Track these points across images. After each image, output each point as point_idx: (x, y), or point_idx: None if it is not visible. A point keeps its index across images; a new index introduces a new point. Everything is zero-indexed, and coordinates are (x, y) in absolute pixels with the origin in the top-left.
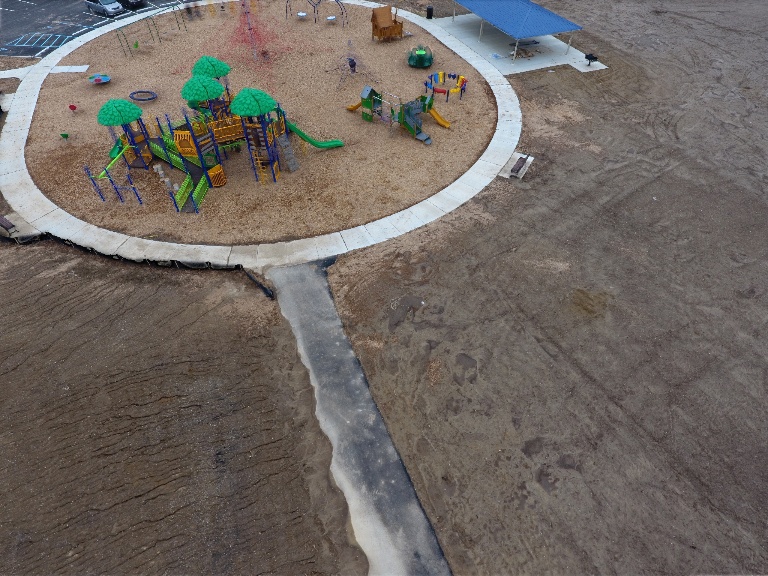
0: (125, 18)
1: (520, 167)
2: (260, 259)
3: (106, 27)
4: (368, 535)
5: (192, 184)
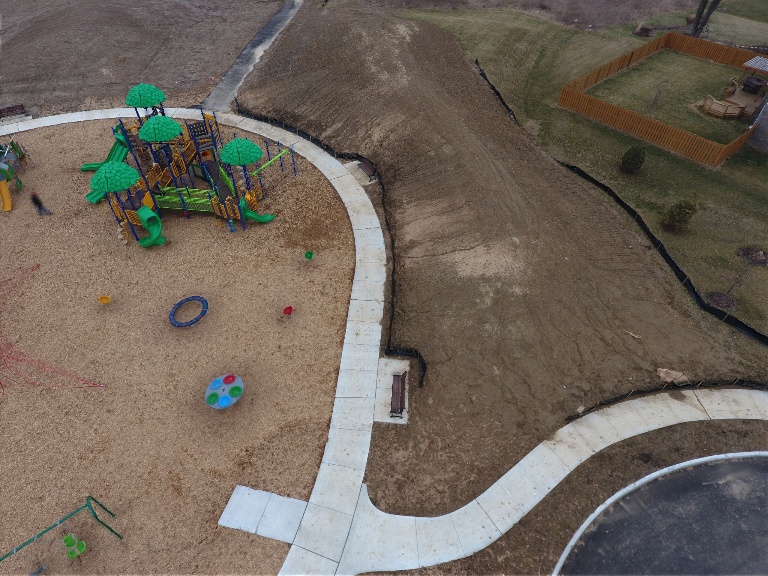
0: None
1: None
2: (226, 117)
3: None
4: None
5: None
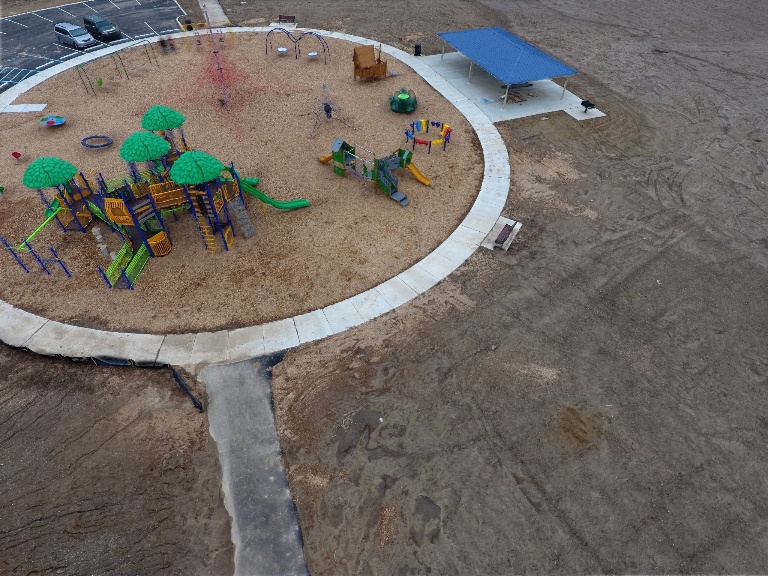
0: (96, 51)
1: (505, 239)
2: (195, 353)
3: (74, 60)
4: None
5: (131, 253)
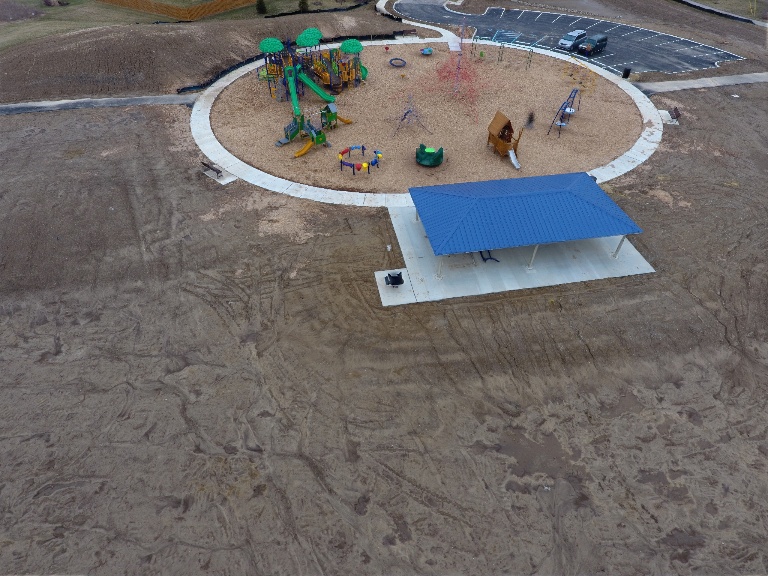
0: (556, 52)
1: None
2: (209, 92)
3: (533, 48)
4: None
5: None
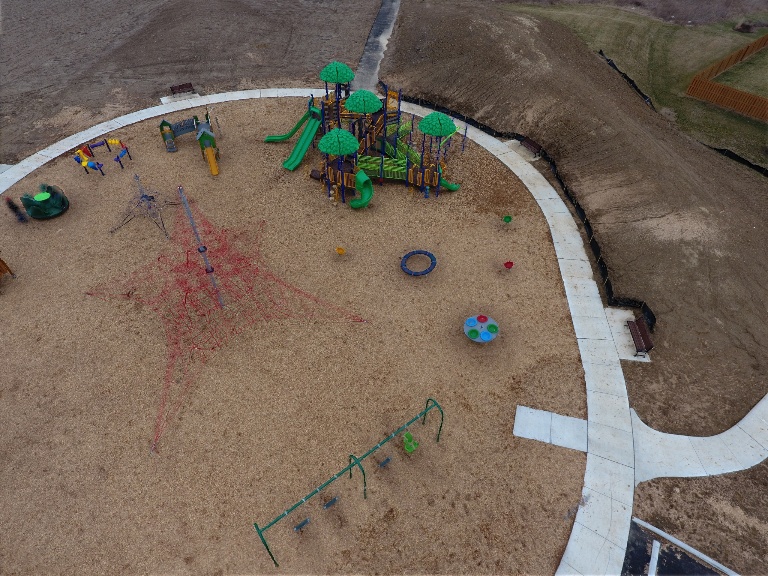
0: None
1: None
2: None
3: None
4: (385, 41)
5: None
